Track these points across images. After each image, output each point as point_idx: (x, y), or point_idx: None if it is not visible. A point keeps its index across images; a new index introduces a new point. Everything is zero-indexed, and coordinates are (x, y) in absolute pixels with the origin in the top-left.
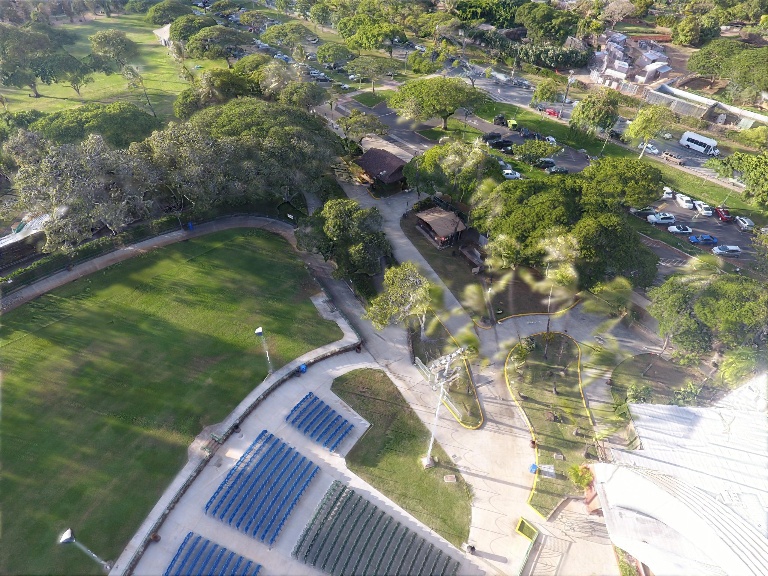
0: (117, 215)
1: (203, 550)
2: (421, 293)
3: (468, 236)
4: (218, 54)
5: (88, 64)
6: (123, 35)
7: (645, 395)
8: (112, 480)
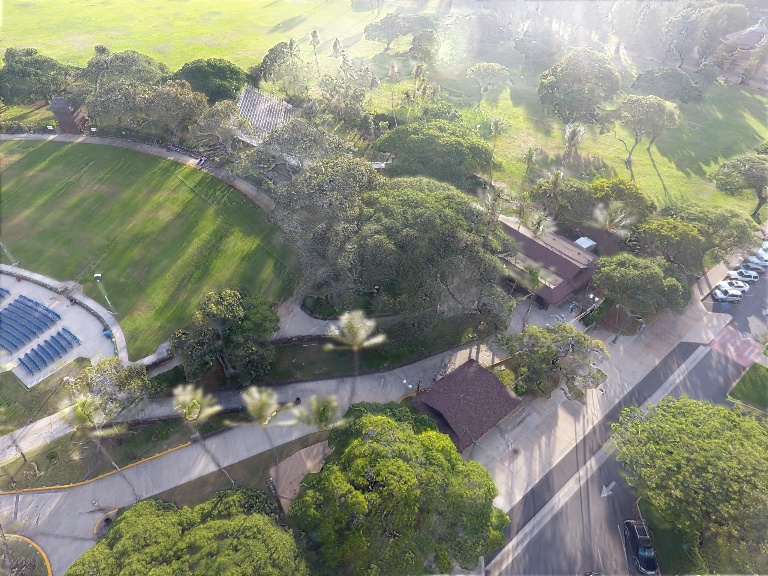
0: None
1: None
2: (87, 396)
3: None
4: (732, 187)
5: (600, 116)
6: (660, 109)
7: None
8: (67, 253)
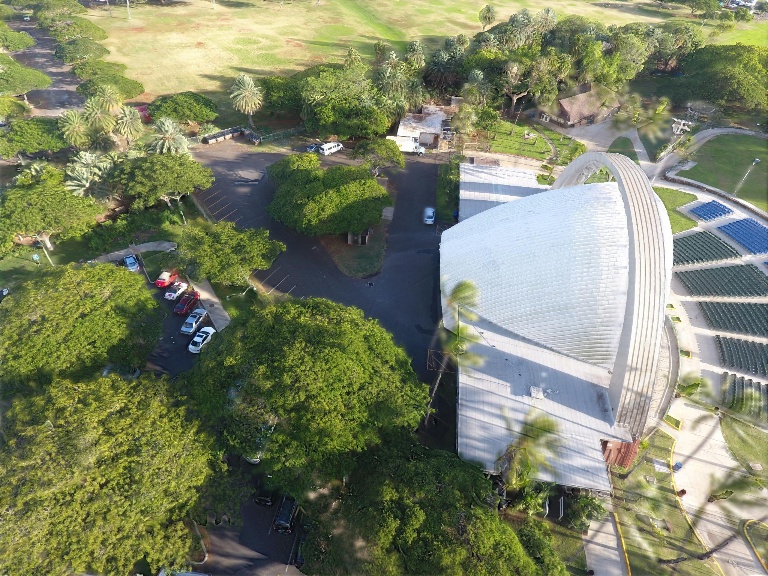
0: None
1: None
2: None
3: None
4: None
5: None
6: None
7: None
8: None
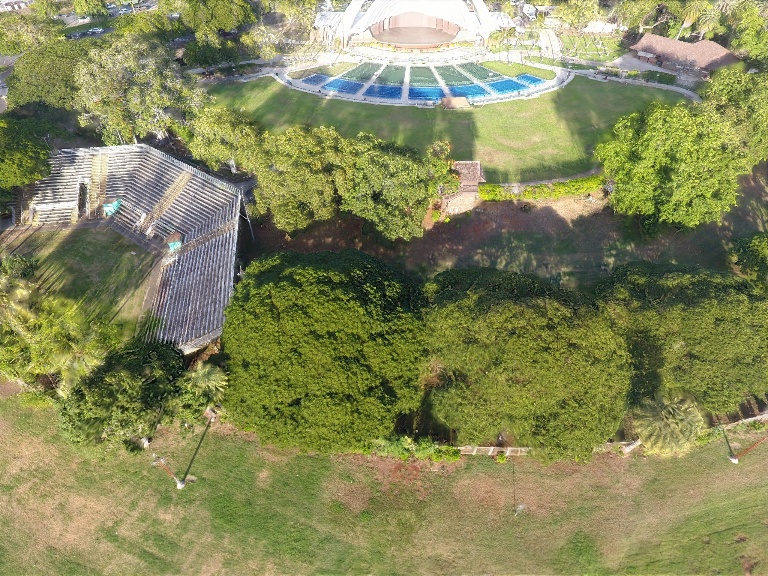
0: None
1: None
2: None
3: None
4: None
5: None
6: None
7: None
8: None
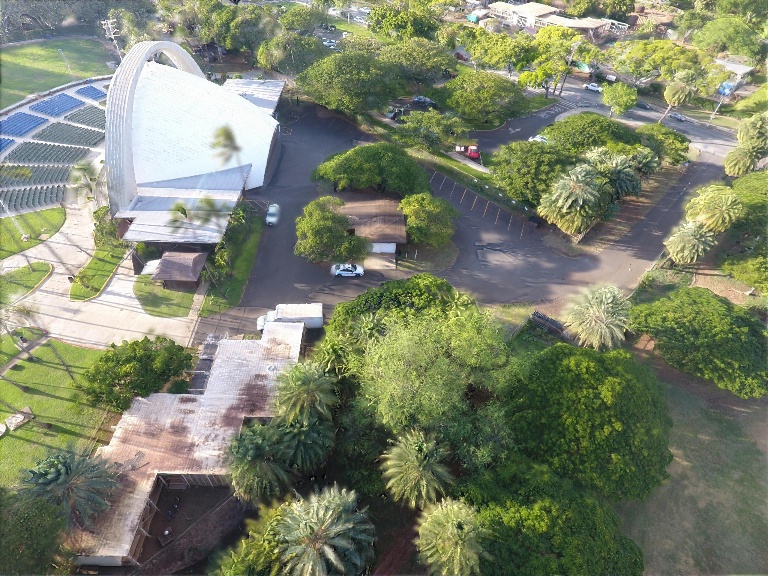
0: (3, 25)
1: (25, 115)
2: None
3: (214, 50)
4: None
5: None
6: None
7: (238, 78)
8: None
